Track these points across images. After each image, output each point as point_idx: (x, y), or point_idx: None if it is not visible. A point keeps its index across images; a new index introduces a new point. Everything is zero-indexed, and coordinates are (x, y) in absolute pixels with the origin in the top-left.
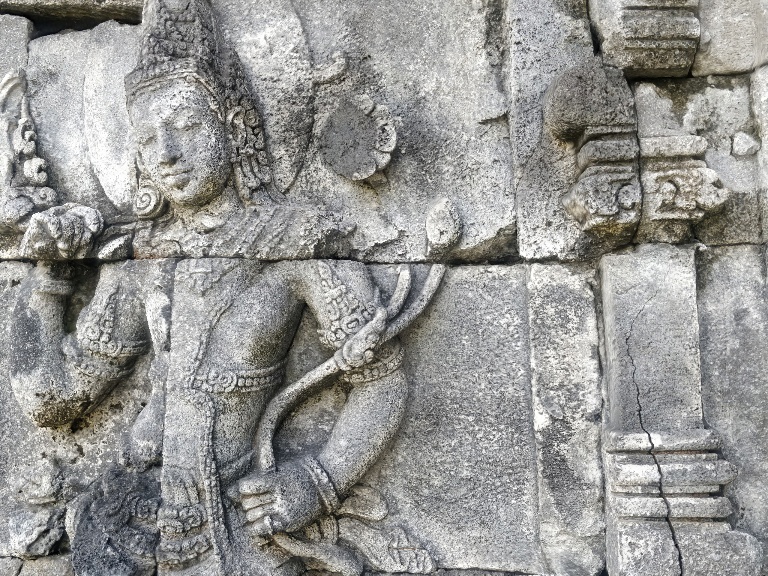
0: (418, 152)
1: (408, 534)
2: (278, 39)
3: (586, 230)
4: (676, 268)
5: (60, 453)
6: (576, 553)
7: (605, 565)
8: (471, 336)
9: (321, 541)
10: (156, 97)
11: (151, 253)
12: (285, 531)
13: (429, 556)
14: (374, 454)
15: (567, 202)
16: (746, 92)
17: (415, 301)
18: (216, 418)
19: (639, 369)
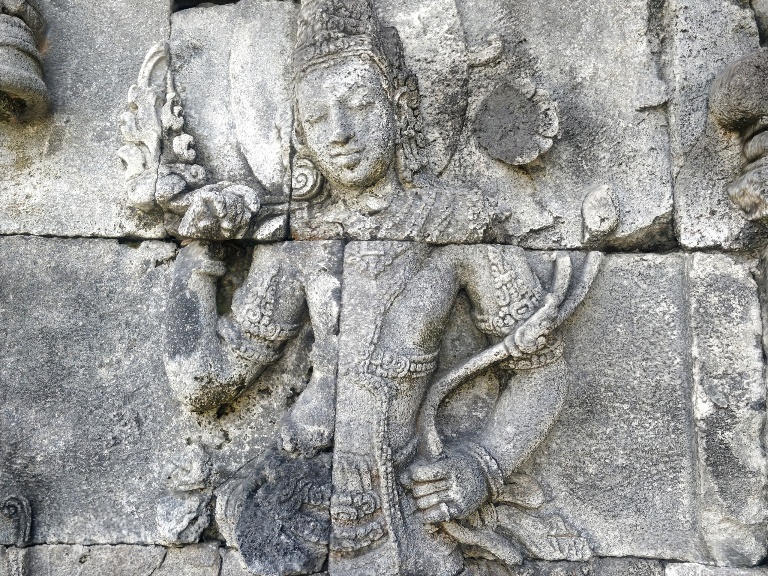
0: (574, 138)
1: (565, 522)
2: (432, 20)
3: (754, 220)
4: None
5: (206, 439)
6: (738, 541)
7: (767, 552)
8: (625, 324)
9: (482, 529)
10: (330, 74)
11: (311, 235)
12: (455, 518)
13: (587, 544)
14: (539, 441)
15: (735, 191)
16: None
17: (577, 288)
18: (389, 403)
19: None
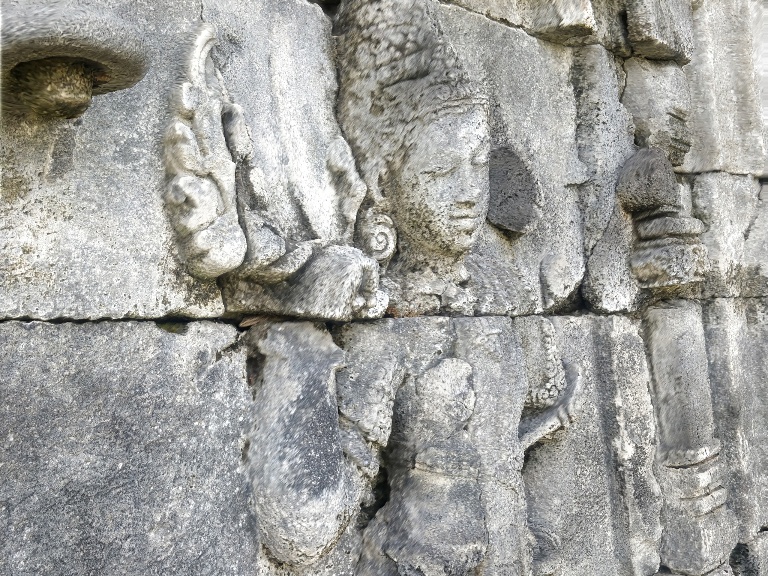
0: None
1: None
2: None
3: (648, 288)
4: (698, 319)
5: None
6: (649, 556)
7: (661, 560)
8: None
9: None
10: (465, 122)
11: (410, 309)
12: None
13: None
14: None
15: (640, 264)
16: (690, 188)
17: None
18: None
19: (694, 398)
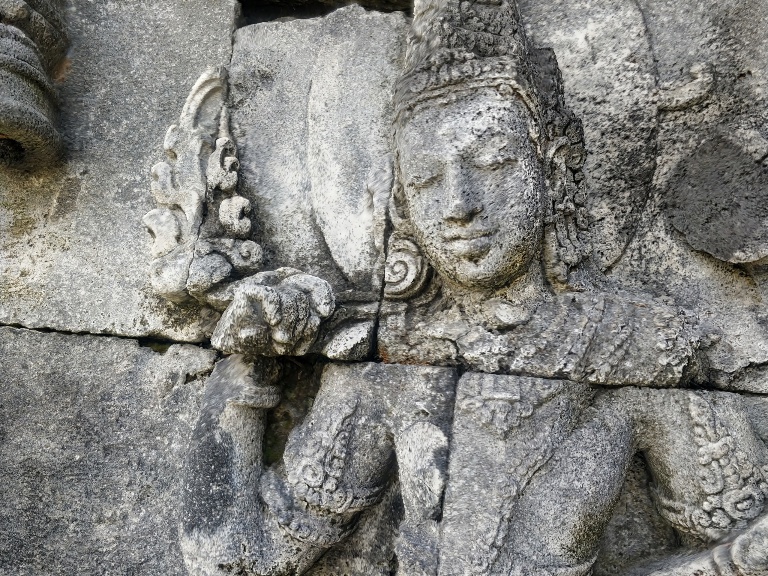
0: None
1: None
2: (606, 40)
3: None
4: None
5: None
6: None
7: None
8: None
9: None
10: (449, 114)
11: (408, 355)
12: None
13: None
14: None
15: None
16: None
17: None
18: None
19: None
